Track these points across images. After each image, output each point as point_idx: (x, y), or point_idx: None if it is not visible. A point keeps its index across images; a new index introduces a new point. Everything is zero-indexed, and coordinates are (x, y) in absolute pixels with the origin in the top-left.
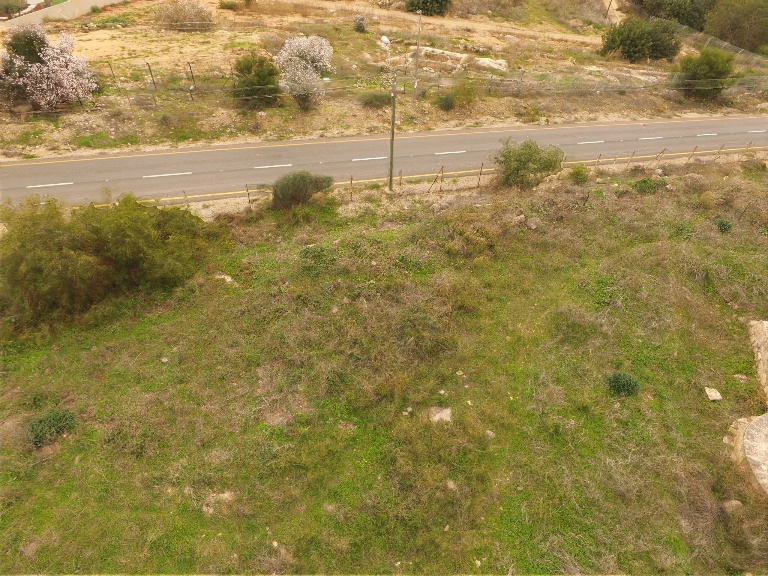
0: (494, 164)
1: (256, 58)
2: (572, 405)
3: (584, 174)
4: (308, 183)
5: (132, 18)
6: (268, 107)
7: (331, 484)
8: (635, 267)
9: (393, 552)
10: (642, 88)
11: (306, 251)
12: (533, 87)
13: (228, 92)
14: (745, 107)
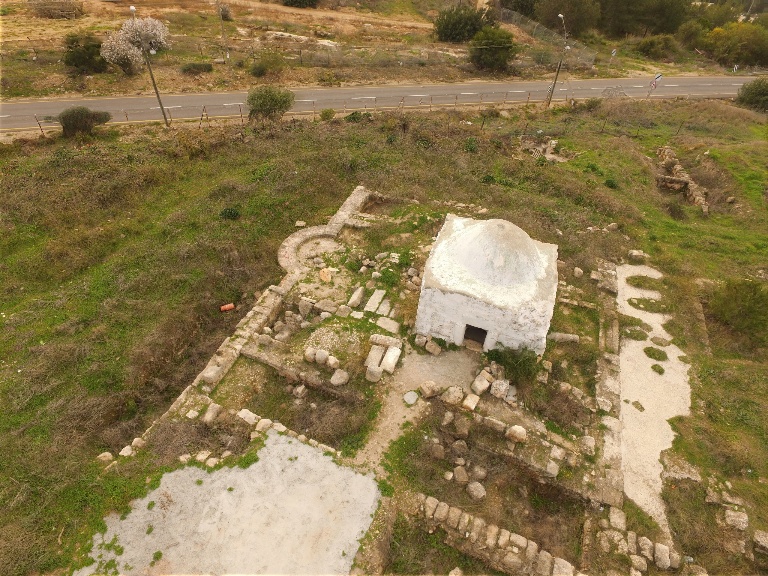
0: (250, 106)
1: (84, 33)
2: (187, 223)
3: (328, 115)
4: (85, 115)
5: (14, 9)
6: (97, 72)
7: (5, 257)
8: (301, 162)
9: (24, 280)
10: (442, 61)
11: (57, 152)
12: (265, 46)
13: (2, 44)
14: (530, 76)
